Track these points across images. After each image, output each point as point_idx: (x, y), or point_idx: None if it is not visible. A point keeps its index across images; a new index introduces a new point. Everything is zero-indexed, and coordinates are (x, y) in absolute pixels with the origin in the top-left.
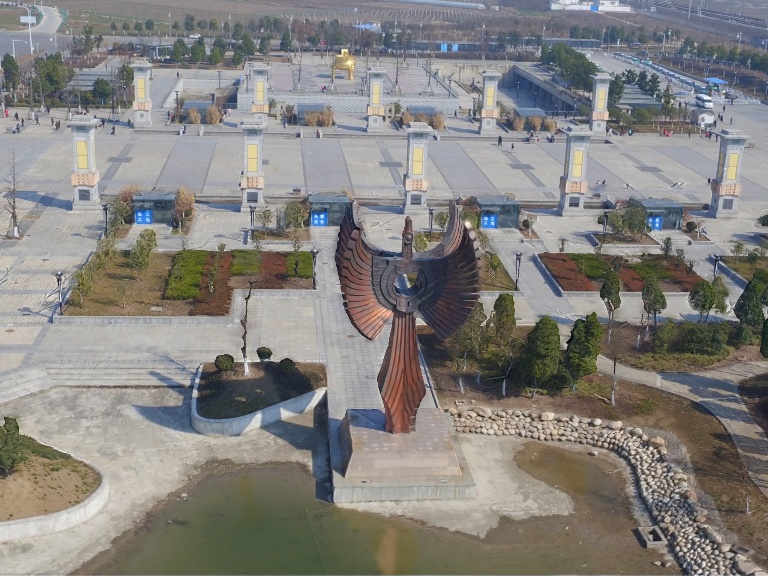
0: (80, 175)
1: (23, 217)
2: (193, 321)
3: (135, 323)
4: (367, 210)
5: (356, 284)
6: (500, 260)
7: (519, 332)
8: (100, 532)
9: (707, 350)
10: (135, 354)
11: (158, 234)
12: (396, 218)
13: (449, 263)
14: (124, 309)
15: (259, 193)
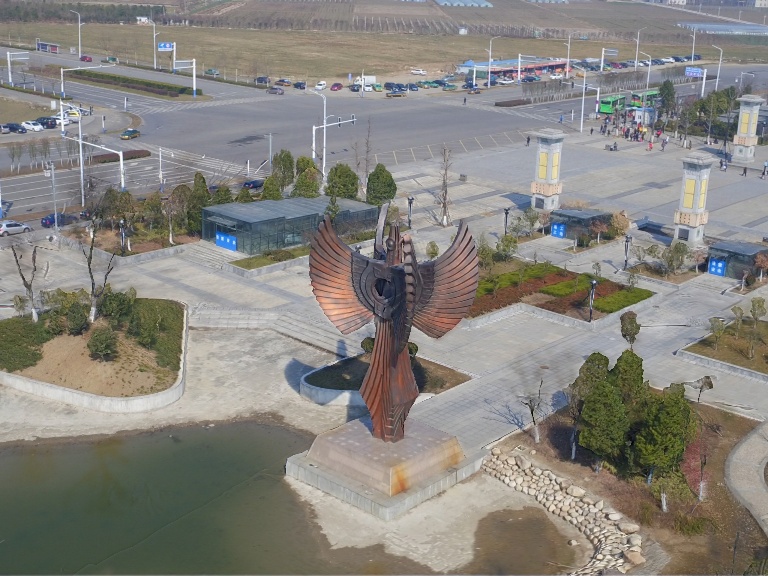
0: (538, 184)
1: (482, 213)
2: None
3: None
4: None
5: (330, 275)
6: None
7: (721, 419)
8: (123, 423)
9: None
10: None
11: (554, 247)
12: None
13: None
14: None
15: (691, 231)
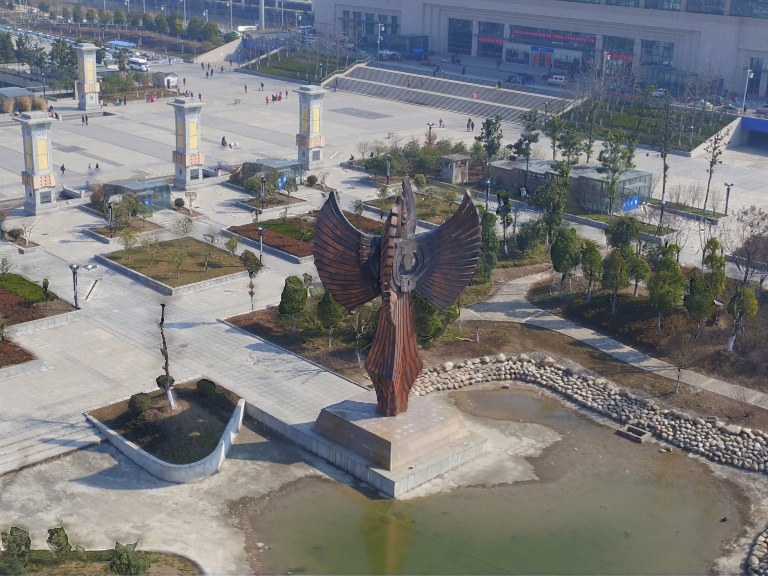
0: None
1: None
2: (1, 375)
3: None
4: None
5: None
6: (204, 242)
7: (316, 303)
8: None
9: (475, 280)
10: None
11: None
12: (33, 221)
13: (443, 235)
14: None
15: None
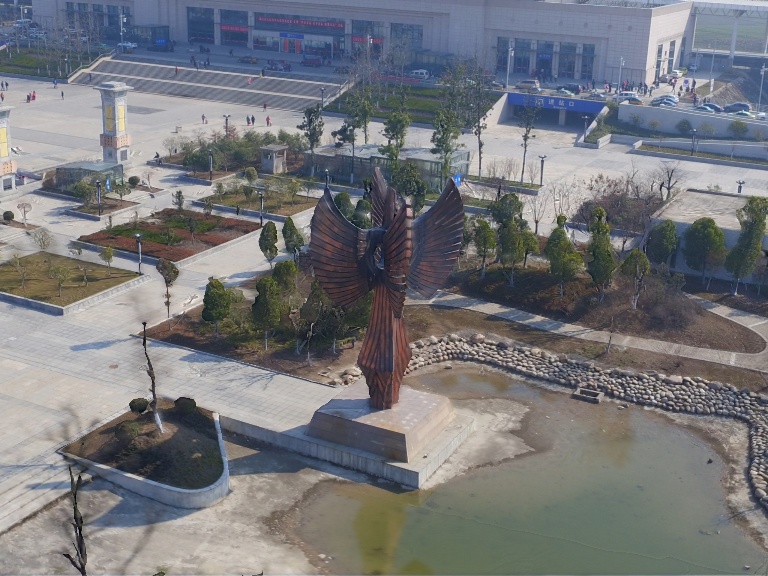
0: None
1: None
2: None
3: None
4: None
5: None
6: (61, 255)
7: None
8: None
9: None
10: None
11: None
12: None
13: (428, 223)
14: None
15: None
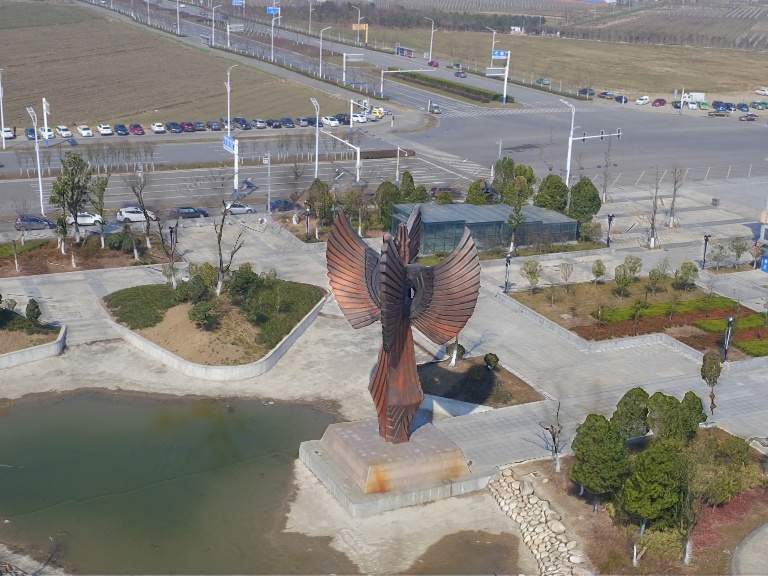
0: None
1: None
2: (566, 334)
3: (535, 319)
4: None
5: (346, 269)
6: None
7: None
8: (198, 388)
9: None
10: (473, 332)
11: (753, 282)
12: None
13: None
14: (547, 307)
15: None
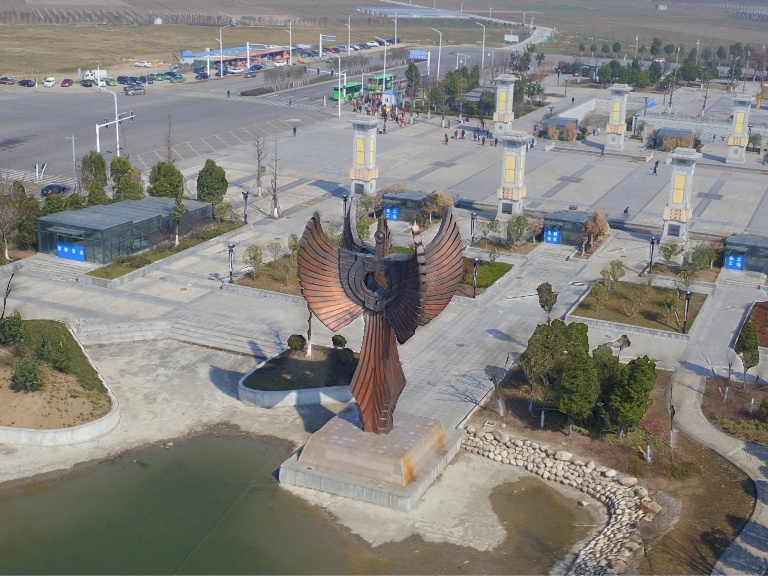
0: (357, 170)
1: (302, 202)
2: None
3: (285, 300)
4: (626, 236)
5: (318, 273)
6: (704, 301)
7: None
8: (75, 455)
9: None
10: (255, 325)
11: (393, 230)
12: (646, 247)
13: (409, 266)
14: (285, 287)
15: (514, 205)
